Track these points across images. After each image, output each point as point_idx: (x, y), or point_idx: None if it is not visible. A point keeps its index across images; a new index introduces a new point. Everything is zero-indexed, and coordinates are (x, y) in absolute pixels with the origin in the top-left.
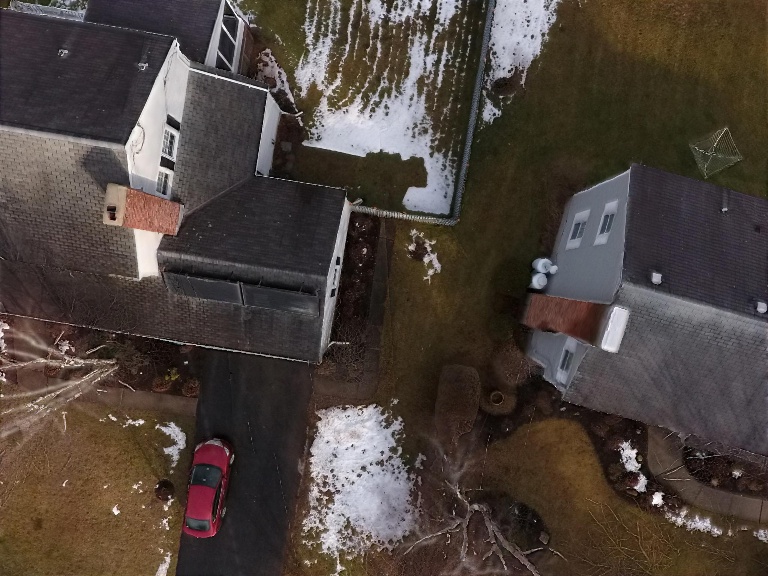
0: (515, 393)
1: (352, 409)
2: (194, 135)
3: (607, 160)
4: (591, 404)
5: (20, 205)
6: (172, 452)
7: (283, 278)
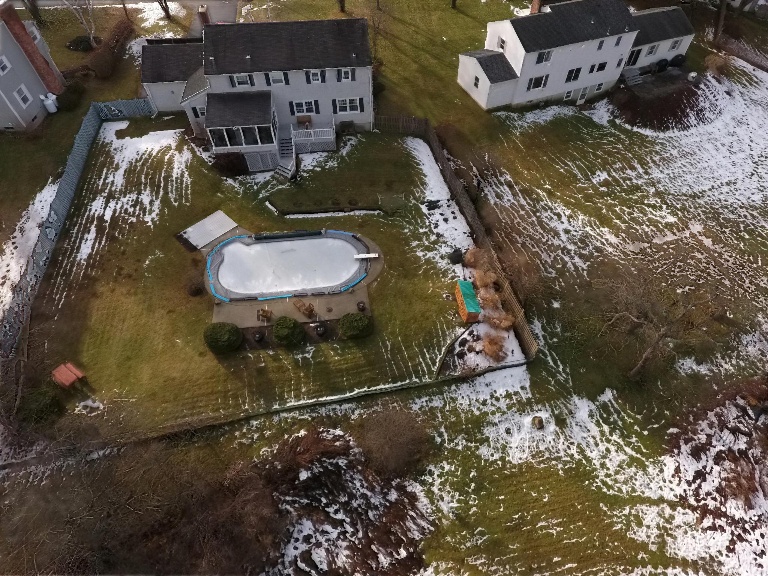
0: (75, 76)
1: None
2: None
3: (3, 151)
4: None
5: None
6: None
7: None
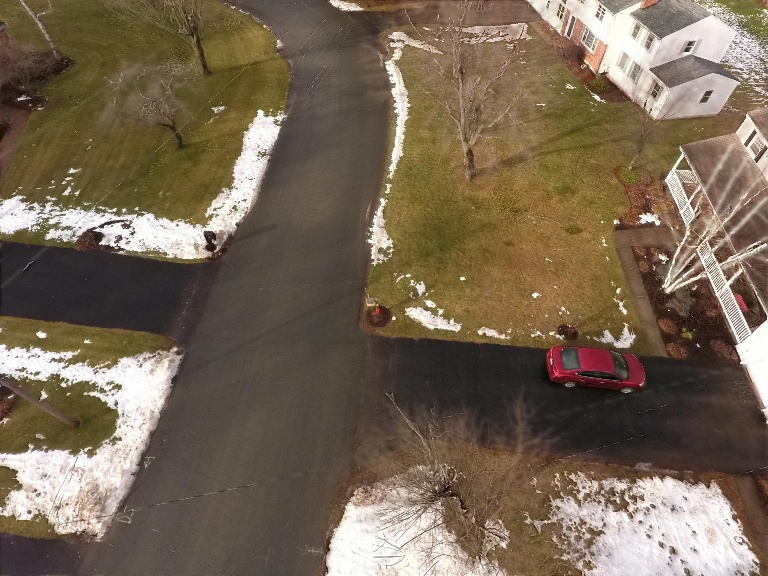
0: None
1: (738, 528)
2: None
3: None
4: None
5: None
6: (608, 337)
7: None
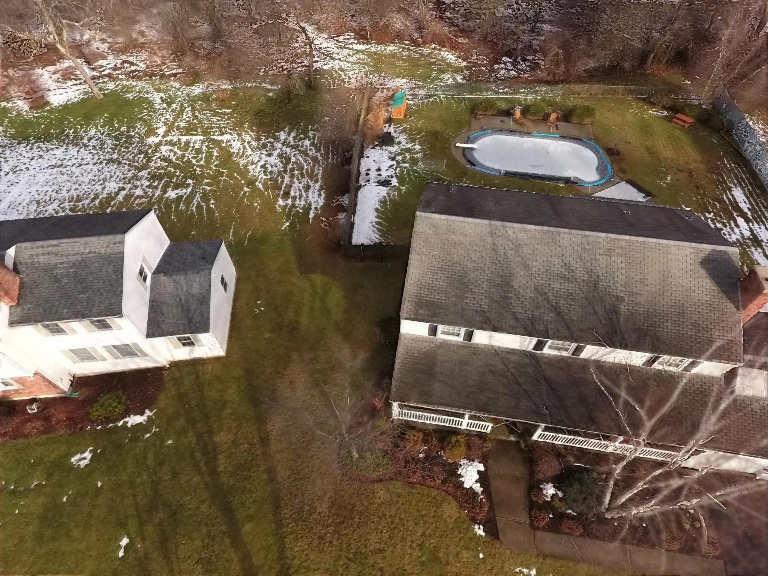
0: None
1: None
2: None
3: None
4: None
5: (636, 298)
6: None
7: None
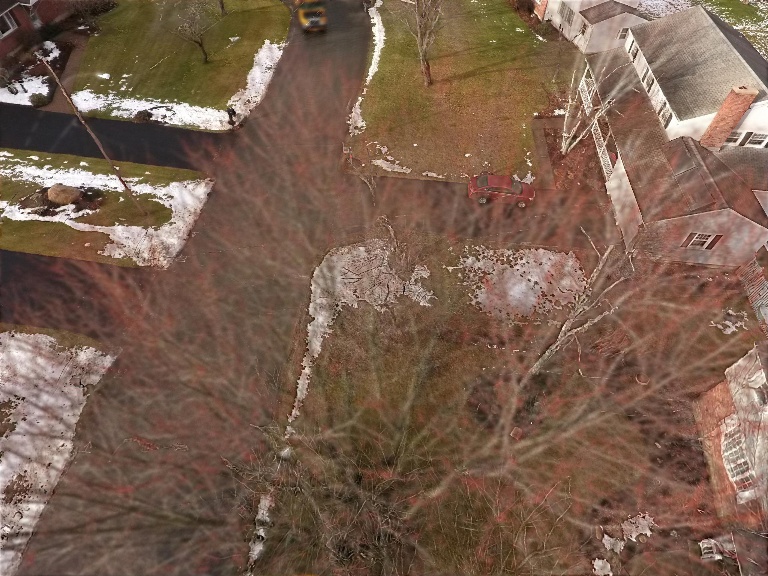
0: (651, 398)
1: (582, 274)
2: (764, 155)
3: None
4: (767, 362)
5: None
6: (515, 178)
7: (710, 189)
